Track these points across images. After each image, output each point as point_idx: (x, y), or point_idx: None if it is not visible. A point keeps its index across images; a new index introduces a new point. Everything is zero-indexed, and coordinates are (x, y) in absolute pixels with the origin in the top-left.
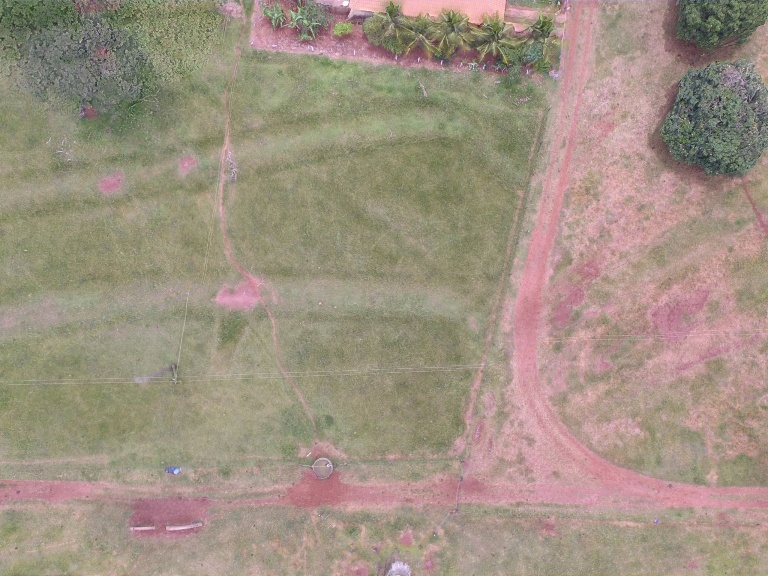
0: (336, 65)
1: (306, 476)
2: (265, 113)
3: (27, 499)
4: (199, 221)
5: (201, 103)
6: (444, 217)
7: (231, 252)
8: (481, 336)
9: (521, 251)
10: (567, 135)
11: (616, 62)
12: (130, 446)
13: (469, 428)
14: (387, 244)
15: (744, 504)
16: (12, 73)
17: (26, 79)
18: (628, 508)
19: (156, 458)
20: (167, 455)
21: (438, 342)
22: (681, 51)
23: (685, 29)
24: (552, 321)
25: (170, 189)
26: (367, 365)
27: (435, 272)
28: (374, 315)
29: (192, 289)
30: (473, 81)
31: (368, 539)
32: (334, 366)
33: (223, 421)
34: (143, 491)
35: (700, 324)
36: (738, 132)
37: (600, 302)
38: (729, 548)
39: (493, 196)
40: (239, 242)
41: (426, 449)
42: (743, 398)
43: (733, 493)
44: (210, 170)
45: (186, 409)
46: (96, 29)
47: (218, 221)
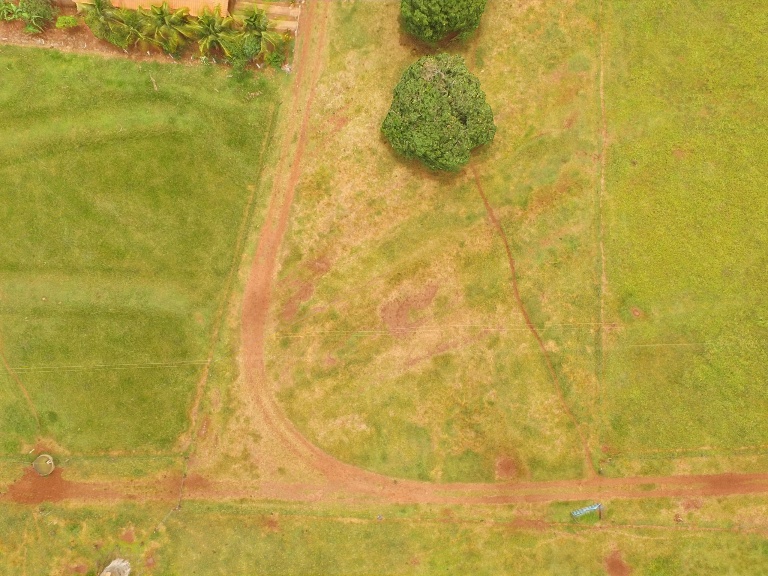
0: (66, 58)
1: (29, 473)
2: None
3: None
4: None
5: None
6: (173, 212)
7: None
8: (207, 332)
9: (250, 246)
10: (298, 129)
11: (350, 56)
12: None
13: (194, 424)
14: (115, 239)
15: (469, 500)
16: None
17: None
18: (352, 504)
19: None
20: None
21: (165, 338)
22: (416, 45)
23: (407, 23)
24: (279, 317)
25: None
26: (92, 361)
27: (164, 267)
28: (99, 311)
29: None
30: (204, 75)
31: (89, 536)
32: (59, 362)
33: None
34: None
35: (429, 319)
36: (437, 126)
37: (328, 297)
38: (452, 544)
39: (224, 191)
40: None
41: (150, 445)
42: (471, 394)
43: (458, 489)
44: None
45: None
46: None
47: None
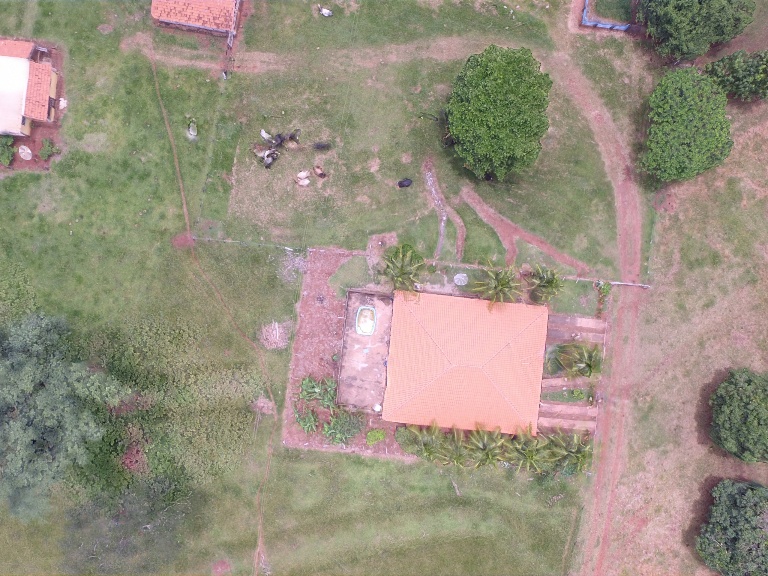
0: (368, 464)
1: None
2: (298, 515)
3: None
4: None
5: (233, 505)
6: None
7: None
8: None
9: None
10: (601, 533)
11: (649, 456)
12: None
13: None
14: None
15: None
16: (44, 477)
17: (58, 483)
18: None
19: None
20: None
21: None
22: (714, 443)
23: (719, 441)
24: None
25: None
26: None
27: None
28: None
29: None
30: (506, 479)
31: None
32: None
33: None
34: None
35: None
36: None
37: None
38: None
39: None
40: None
41: None
42: None
43: None
44: (243, 575)
45: None
46: (127, 429)
47: None
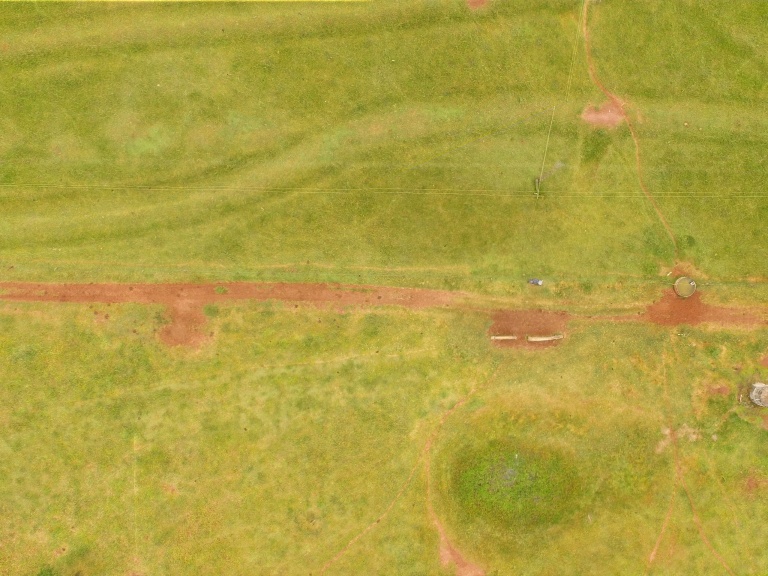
0: None
1: (666, 295)
2: None
3: (388, 305)
4: (563, 40)
5: None
6: None
7: (595, 71)
8: None
9: None
10: None
11: None
12: (491, 257)
13: None
14: (752, 69)
15: None
16: None
17: None
18: None
19: (517, 270)
20: (529, 267)
21: None
22: None
23: None
24: None
25: (534, 8)
26: (729, 188)
27: None
28: (739, 138)
29: (557, 105)
30: None
31: (729, 359)
32: (696, 188)
33: (584, 237)
34: (503, 302)
35: None
36: None
37: None
38: None
39: None
40: (603, 62)
41: None
42: None
43: None
44: None
45: (548, 223)
46: None
47: (582, 40)
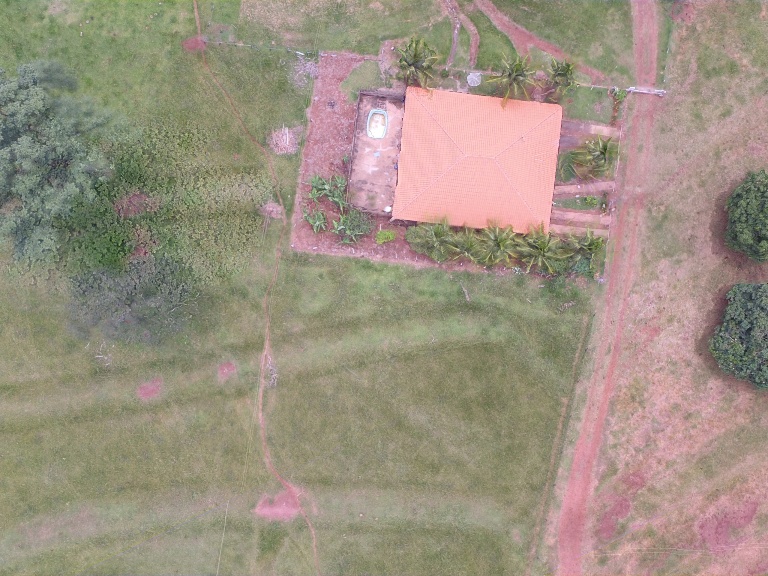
0: (377, 268)
1: None
2: (305, 317)
3: None
4: (238, 428)
5: (241, 307)
6: (487, 425)
7: (271, 460)
8: (525, 549)
9: (565, 461)
10: (612, 341)
11: (662, 265)
12: None
13: None
14: (429, 453)
15: None
16: (51, 276)
17: (65, 282)
18: None
19: None
20: None
21: (481, 554)
22: (728, 253)
23: (734, 241)
24: (597, 534)
25: (209, 394)
26: None
27: (478, 481)
28: (416, 527)
29: (231, 499)
30: (516, 285)
31: None
32: None
33: None
34: None
35: (749, 537)
36: None
37: (646, 515)
38: None
39: (537, 402)
40: (279, 450)
41: None
42: None
43: None
44: (250, 376)
45: None
46: (135, 230)
47: (258, 428)
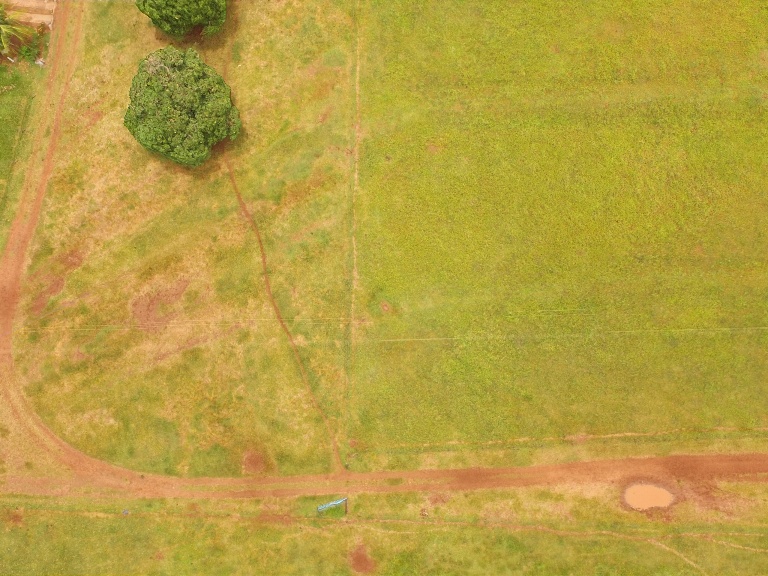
0: None
1: None
2: None
3: None
4: None
5: None
6: None
7: None
8: None
9: (0, 240)
10: (51, 123)
11: (106, 50)
12: None
13: None
14: None
15: (216, 495)
16: None
17: None
18: (99, 499)
19: None
20: None
21: None
22: (173, 39)
23: None
24: (29, 311)
25: None
26: None
27: None
28: None
29: None
30: None
31: None
32: None
33: None
34: None
35: (179, 314)
36: (159, 120)
37: (77, 292)
38: (197, 539)
39: None
40: None
41: None
42: (220, 388)
43: (205, 484)
44: None
45: None
46: None
47: None
